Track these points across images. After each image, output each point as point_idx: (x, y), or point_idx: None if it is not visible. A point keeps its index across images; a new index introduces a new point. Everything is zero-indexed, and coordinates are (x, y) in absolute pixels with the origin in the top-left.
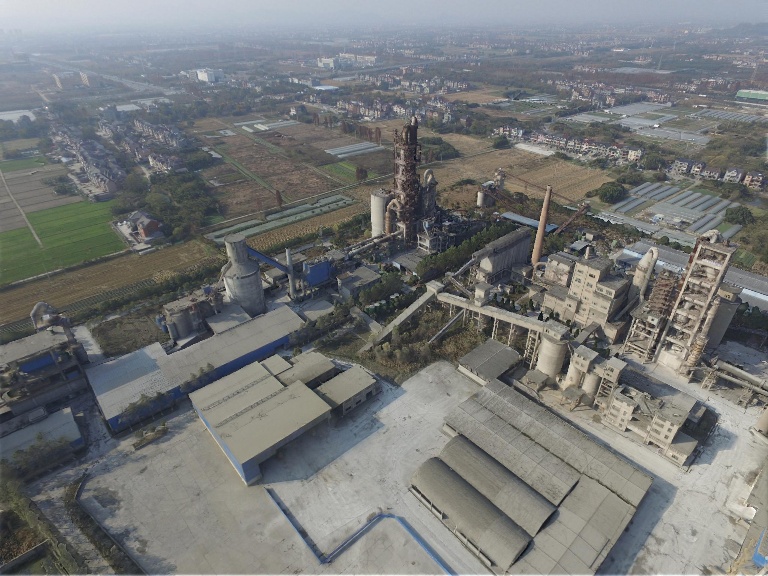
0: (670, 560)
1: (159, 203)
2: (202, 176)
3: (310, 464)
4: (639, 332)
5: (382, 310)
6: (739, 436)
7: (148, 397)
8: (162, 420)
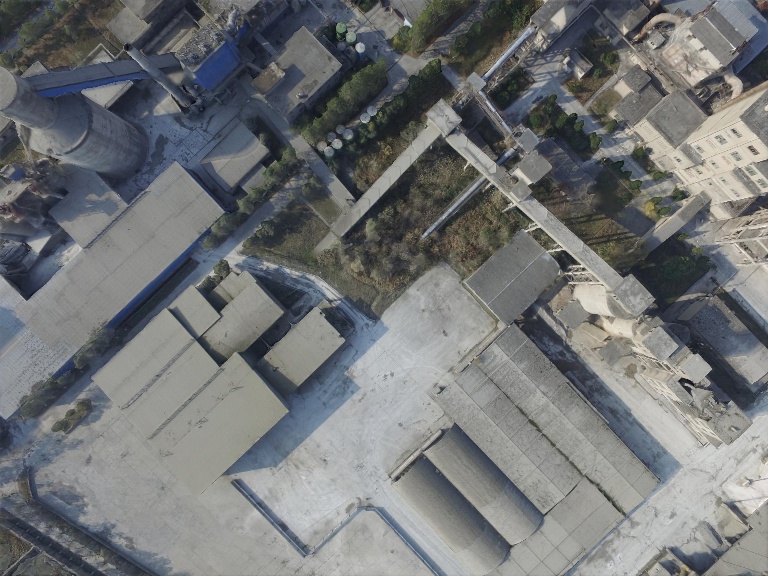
0: (635, 543)
1: None
2: None
3: (276, 448)
4: (766, 249)
5: (347, 152)
6: None
7: (39, 394)
8: (76, 388)
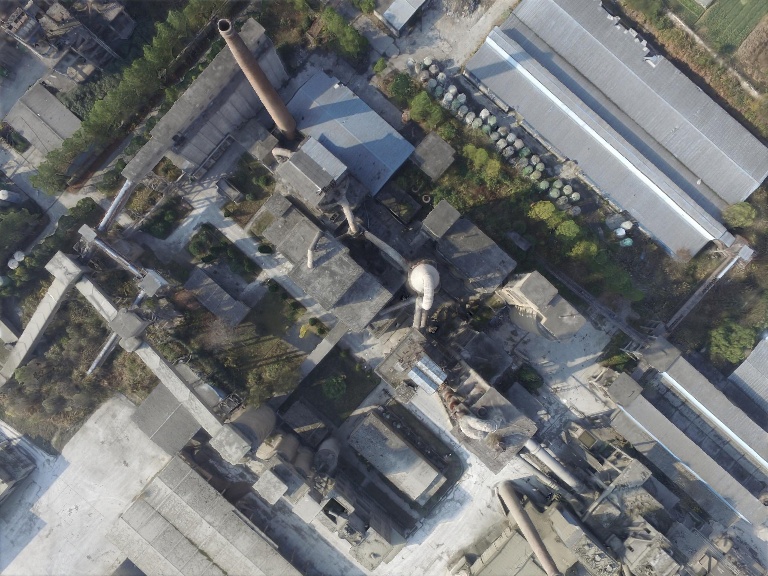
0: None
1: None
2: None
3: None
4: None
5: (4, 296)
6: (475, 500)
7: None
8: None
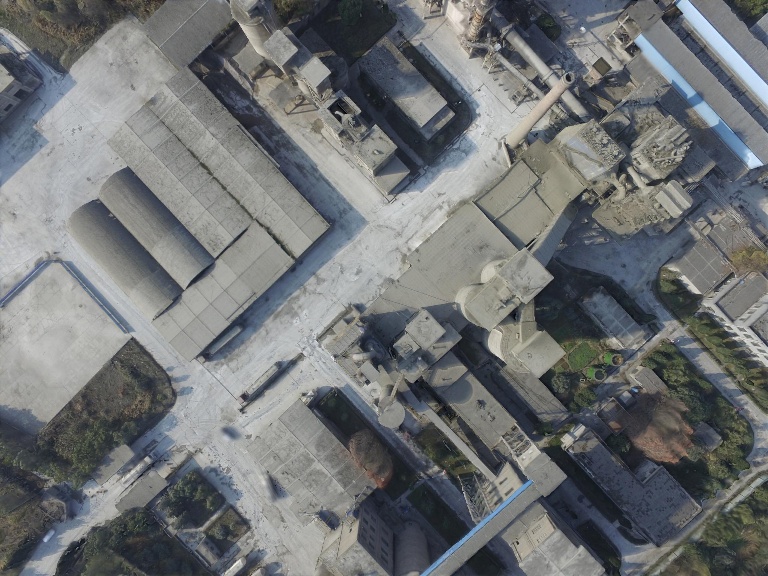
0: (321, 299)
1: None
2: None
3: None
4: None
5: None
6: (481, 150)
7: None
8: None
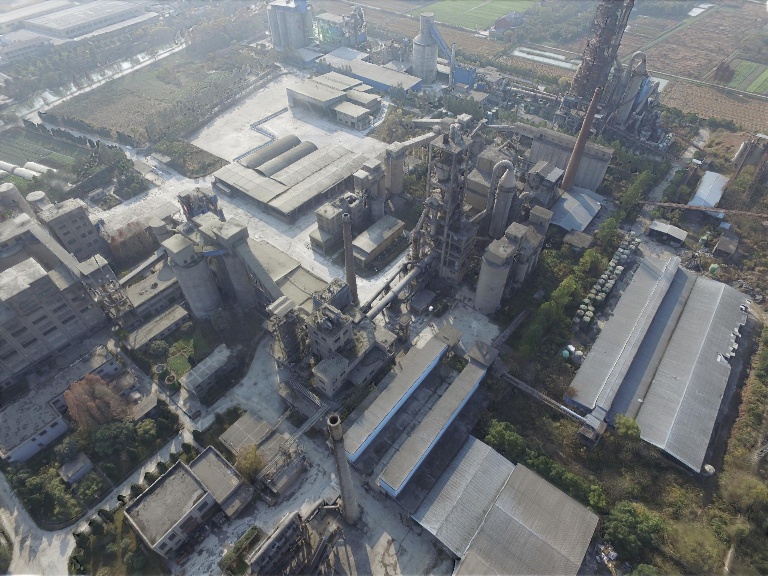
0: None
1: (541, 15)
2: (633, 20)
3: (303, 117)
4: None
5: None
6: None
7: None
8: None
